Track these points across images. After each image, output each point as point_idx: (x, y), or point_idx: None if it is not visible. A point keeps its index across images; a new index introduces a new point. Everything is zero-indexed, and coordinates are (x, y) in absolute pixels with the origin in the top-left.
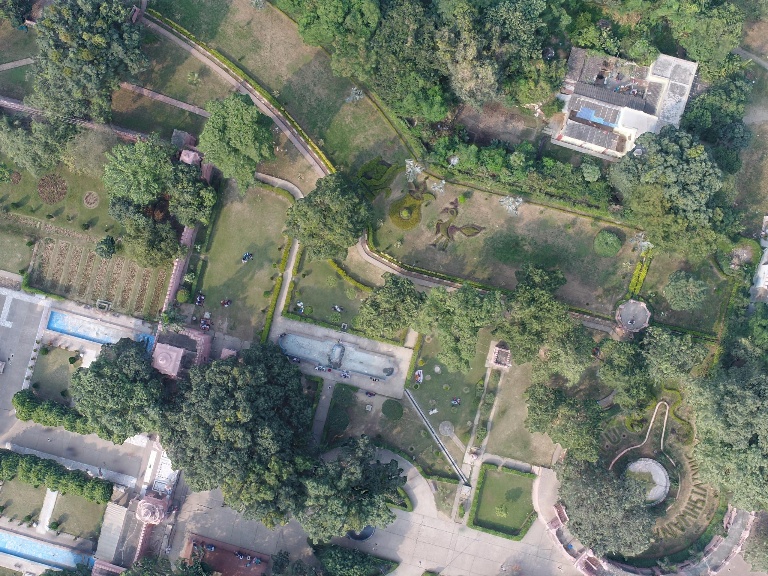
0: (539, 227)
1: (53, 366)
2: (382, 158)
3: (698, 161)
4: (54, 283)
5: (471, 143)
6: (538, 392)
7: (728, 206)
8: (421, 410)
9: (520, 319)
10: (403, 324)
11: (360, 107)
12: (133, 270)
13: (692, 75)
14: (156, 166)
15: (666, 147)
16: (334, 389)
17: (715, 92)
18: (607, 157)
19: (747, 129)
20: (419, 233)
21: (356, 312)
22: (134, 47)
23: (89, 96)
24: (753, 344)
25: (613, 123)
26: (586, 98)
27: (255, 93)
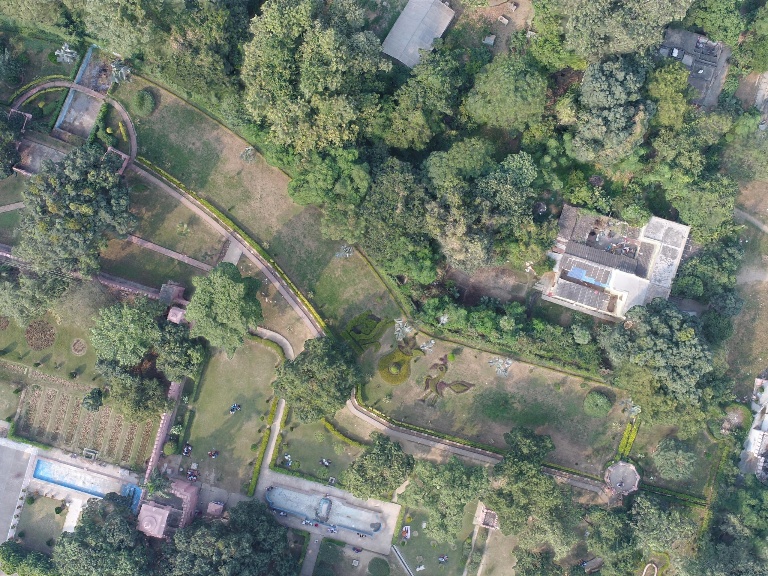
0: (529, 385)
1: (39, 514)
2: (372, 312)
3: (688, 346)
4: (41, 430)
5: (461, 298)
6: (525, 560)
7: (719, 378)
8: (408, 566)
9: (508, 490)
10: (390, 489)
11: (350, 260)
12: (120, 419)
13: (684, 238)
14: (143, 331)
15: (656, 327)
16: (321, 544)
17: (707, 260)
18: (598, 314)
19: (739, 289)
20: (408, 388)
21: (344, 466)
22: (122, 211)
23: (77, 255)
24: (742, 523)
25: (604, 283)
26: (577, 258)
27: (245, 243)
